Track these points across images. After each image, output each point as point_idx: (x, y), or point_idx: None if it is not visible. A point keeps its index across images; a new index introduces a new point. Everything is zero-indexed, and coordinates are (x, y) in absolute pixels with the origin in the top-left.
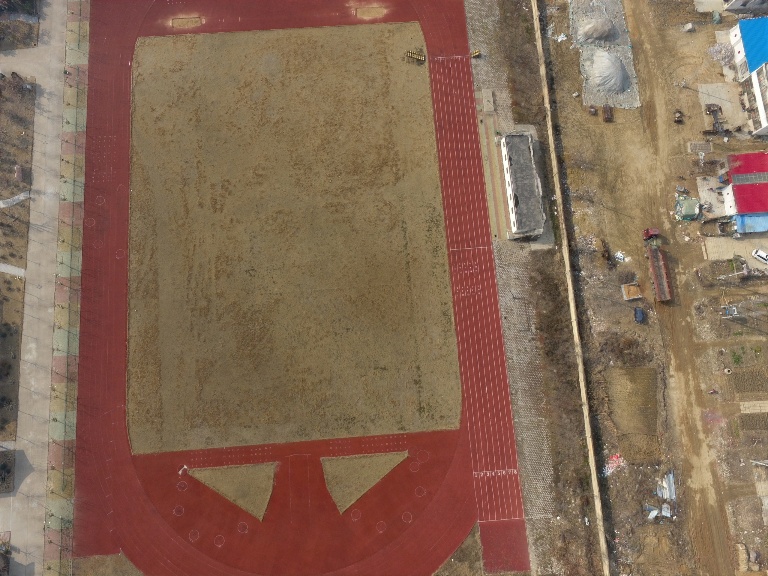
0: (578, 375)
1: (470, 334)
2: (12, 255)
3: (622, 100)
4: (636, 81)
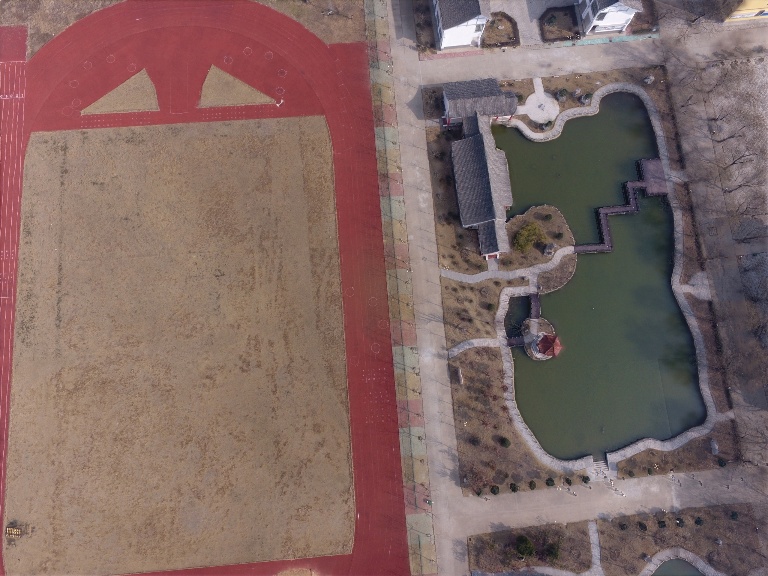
0: None
1: (6, 214)
2: (455, 290)
3: None
4: None
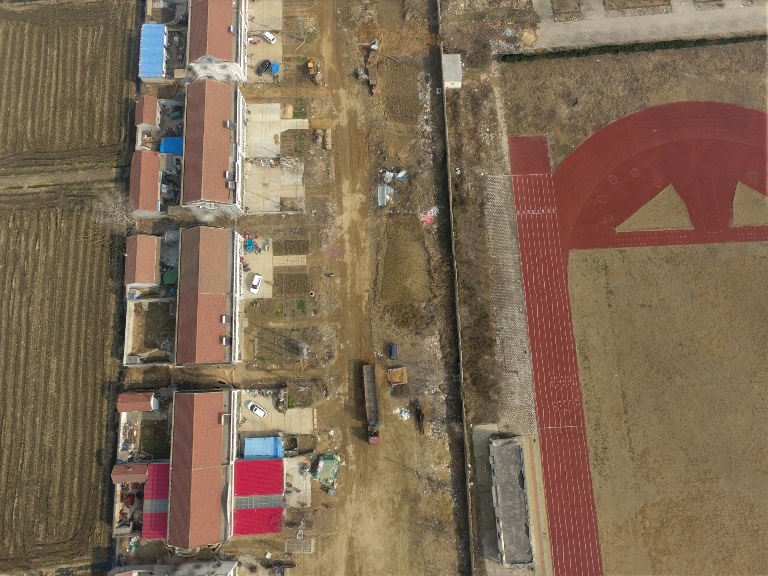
0: (459, 294)
1: (561, 337)
2: None
3: None
4: None
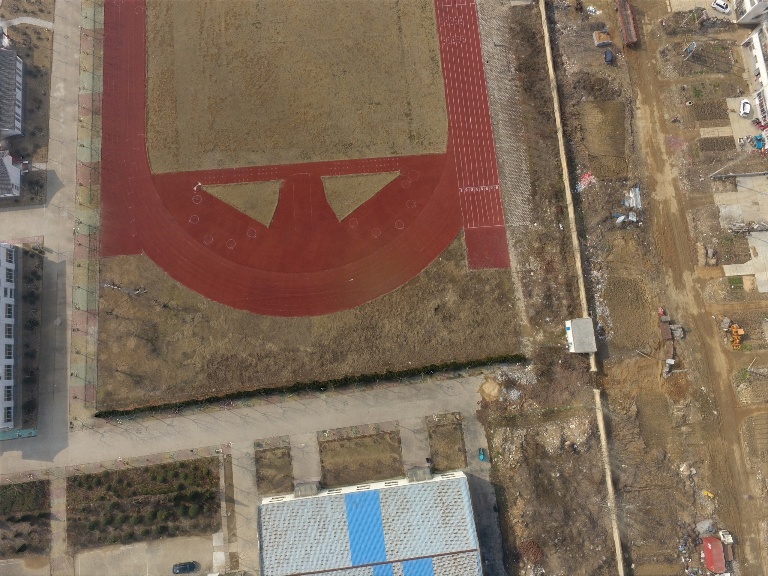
0: (553, 107)
1: (456, 75)
2: (41, 10)
3: None
4: None
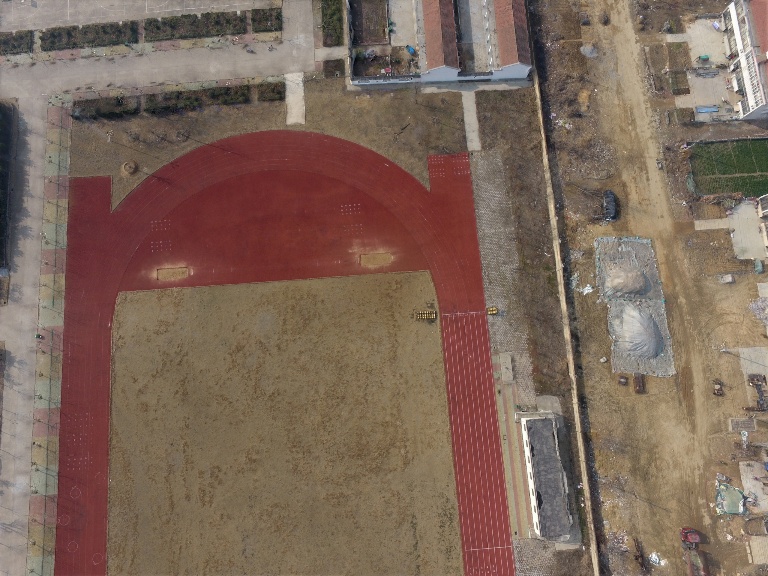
0: None
1: None
2: None
3: (655, 366)
4: (670, 343)
